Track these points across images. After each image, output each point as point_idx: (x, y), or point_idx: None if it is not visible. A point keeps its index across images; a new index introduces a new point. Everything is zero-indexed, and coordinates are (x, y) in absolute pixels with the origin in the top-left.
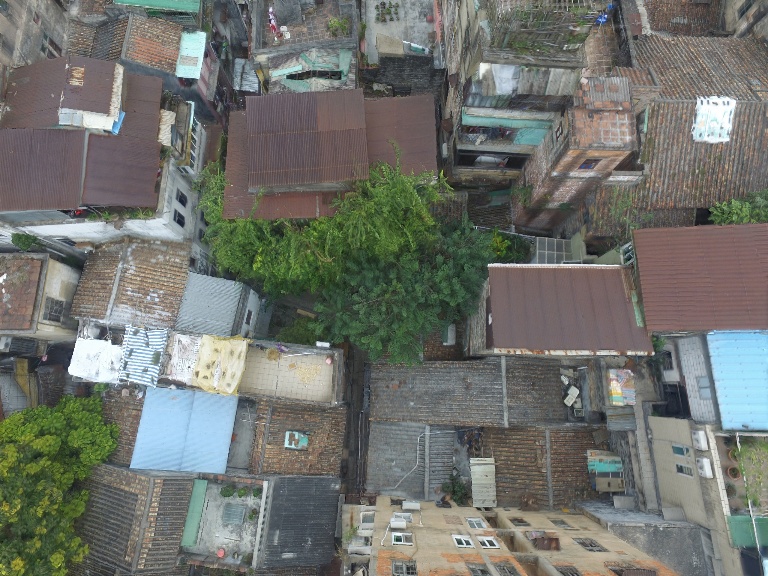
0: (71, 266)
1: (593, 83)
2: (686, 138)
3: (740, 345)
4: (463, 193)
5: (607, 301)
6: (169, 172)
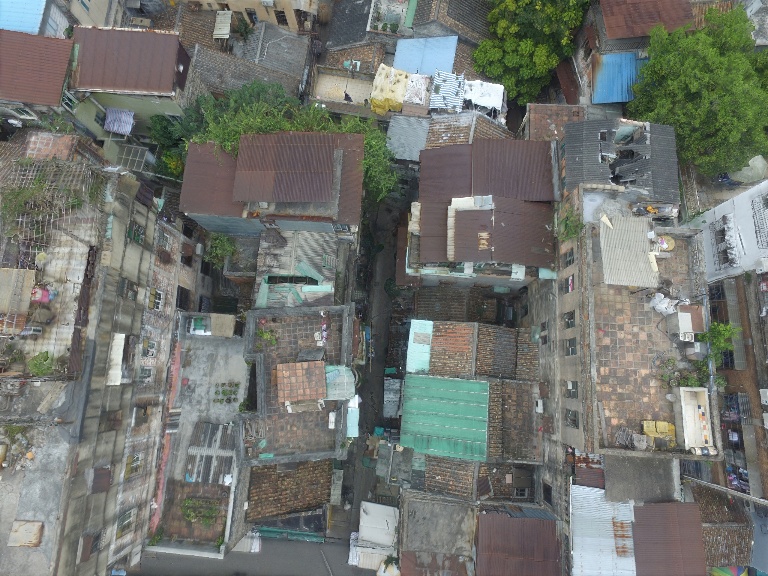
0: None
1: None
2: None
3: None
4: None
5: (94, 64)
6: None
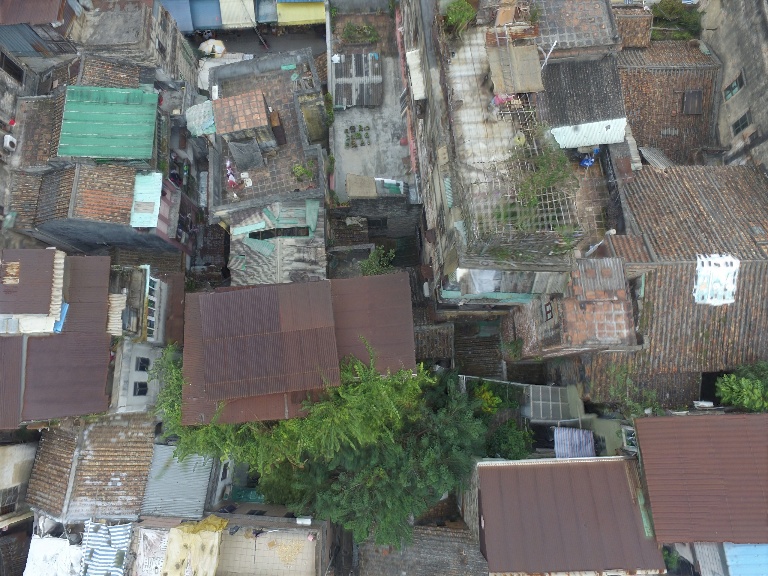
0: (26, 442)
1: (583, 267)
2: (687, 300)
3: (760, 552)
4: (449, 325)
5: (611, 504)
6: (123, 355)
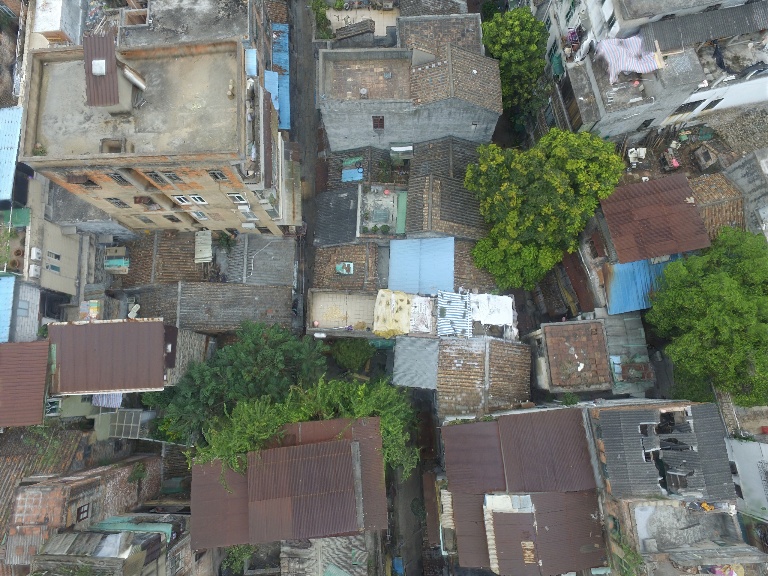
0: None
1: None
2: None
3: None
4: None
5: (75, 364)
6: None
